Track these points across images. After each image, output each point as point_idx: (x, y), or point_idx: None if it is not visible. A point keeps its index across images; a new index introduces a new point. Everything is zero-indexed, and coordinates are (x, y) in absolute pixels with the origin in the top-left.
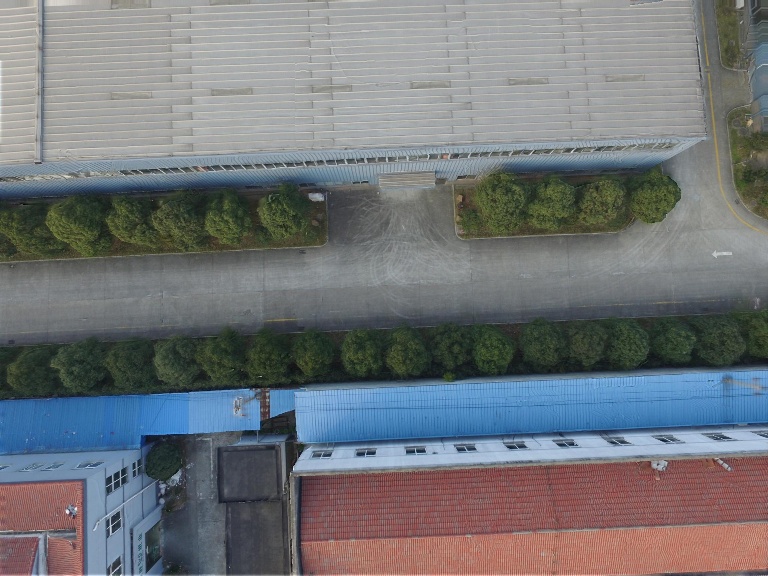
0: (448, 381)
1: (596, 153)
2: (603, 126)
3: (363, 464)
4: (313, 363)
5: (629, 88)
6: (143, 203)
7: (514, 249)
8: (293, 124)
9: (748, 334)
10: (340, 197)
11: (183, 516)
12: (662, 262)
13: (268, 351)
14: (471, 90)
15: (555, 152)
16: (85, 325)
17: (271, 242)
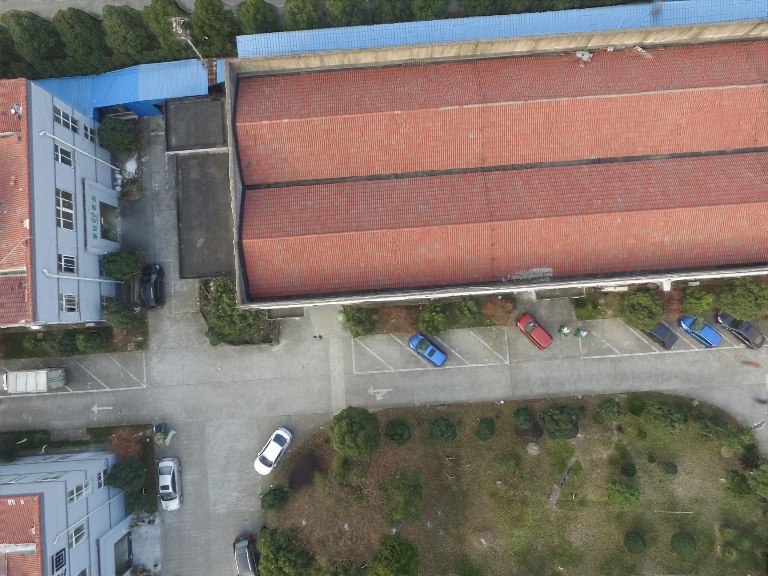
0: None
1: None
2: None
3: None
4: (254, 8)
5: None
6: None
7: None
8: None
9: None
10: None
11: (139, 206)
12: None
13: None
14: None
15: None
16: None
17: None
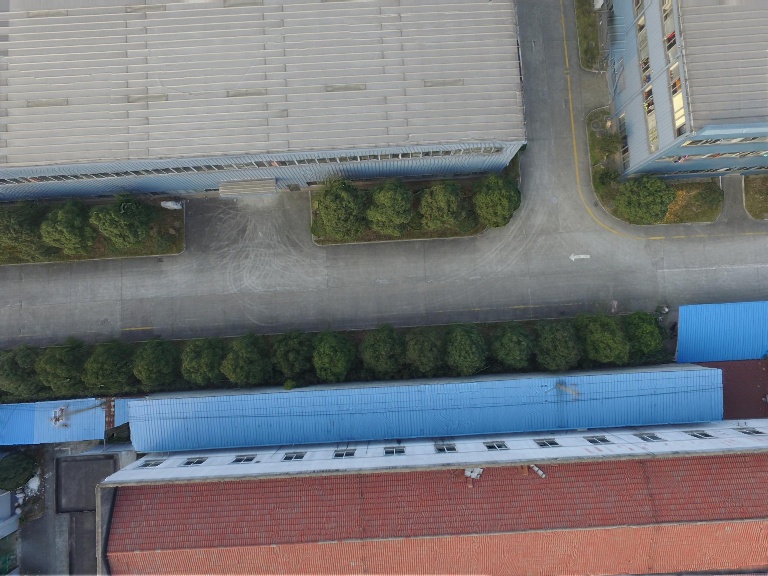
0: (285, 389)
1: (427, 158)
2: (425, 131)
3: (175, 474)
4: (146, 372)
5: (449, 93)
6: None
7: (370, 255)
8: (108, 134)
9: (586, 338)
10: (198, 205)
11: (41, 525)
12: (519, 266)
13: (101, 361)
14: (288, 97)
15: (383, 158)
16: None
17: (128, 251)
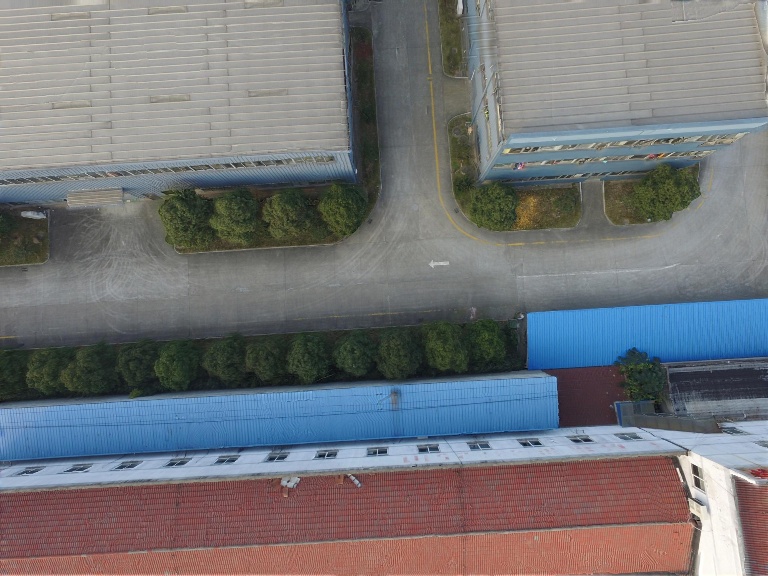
0: (128, 398)
1: (263, 167)
2: (253, 141)
3: None
4: None
5: (274, 102)
6: None
7: (231, 263)
8: None
9: (425, 346)
10: (62, 214)
11: None
12: (378, 273)
13: None
14: (112, 109)
15: (217, 167)
16: None
17: None
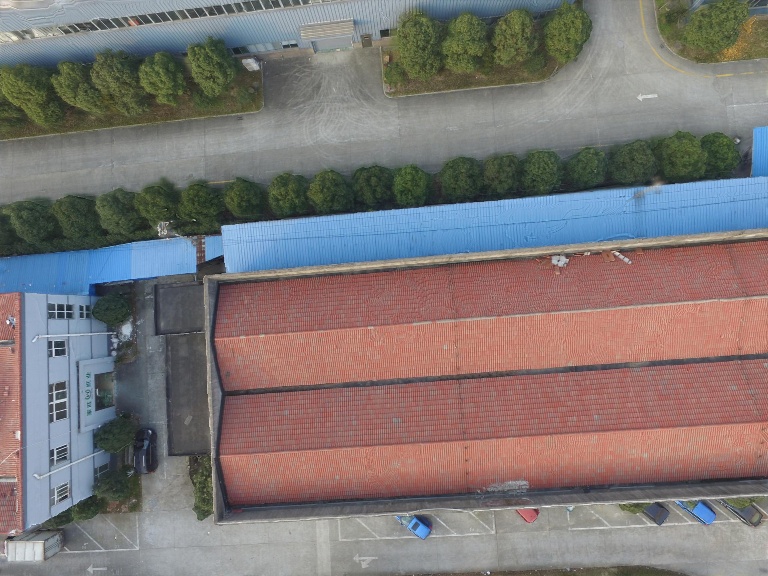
0: None
1: None
2: None
3: None
4: (238, 198)
5: None
6: (85, 66)
7: (440, 104)
8: None
9: (662, 153)
10: (274, 66)
11: (134, 368)
12: (587, 108)
13: (196, 188)
14: None
15: None
16: (44, 196)
17: (210, 110)
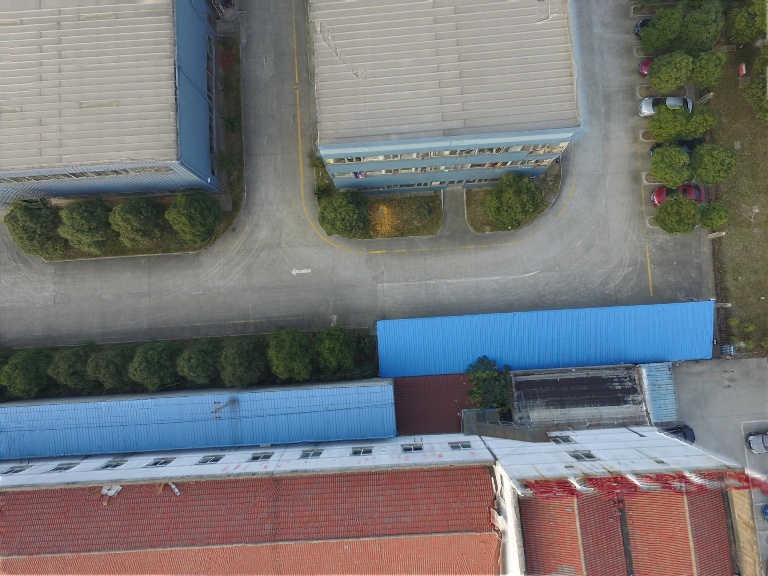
0: None
1: (104, 177)
2: (87, 152)
3: None
4: None
5: (106, 113)
6: None
7: (97, 271)
8: None
9: (267, 355)
10: None
11: None
12: (241, 281)
13: None
14: None
15: None
16: None
17: None
